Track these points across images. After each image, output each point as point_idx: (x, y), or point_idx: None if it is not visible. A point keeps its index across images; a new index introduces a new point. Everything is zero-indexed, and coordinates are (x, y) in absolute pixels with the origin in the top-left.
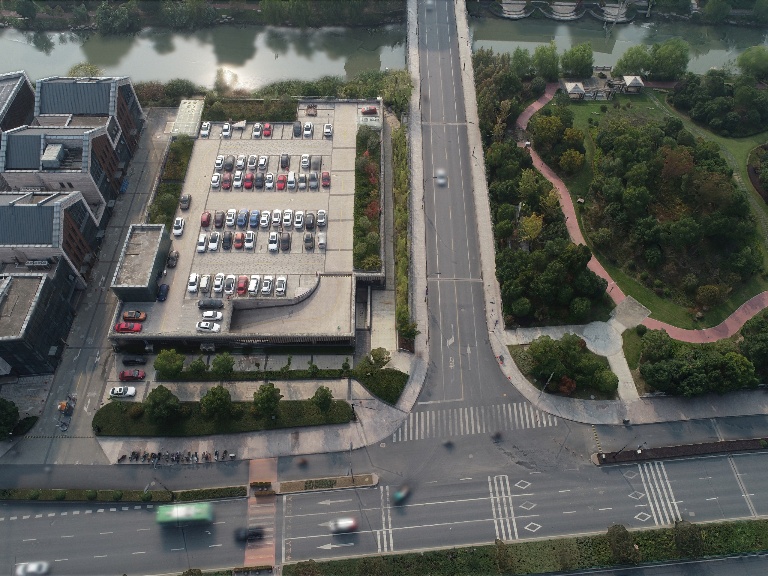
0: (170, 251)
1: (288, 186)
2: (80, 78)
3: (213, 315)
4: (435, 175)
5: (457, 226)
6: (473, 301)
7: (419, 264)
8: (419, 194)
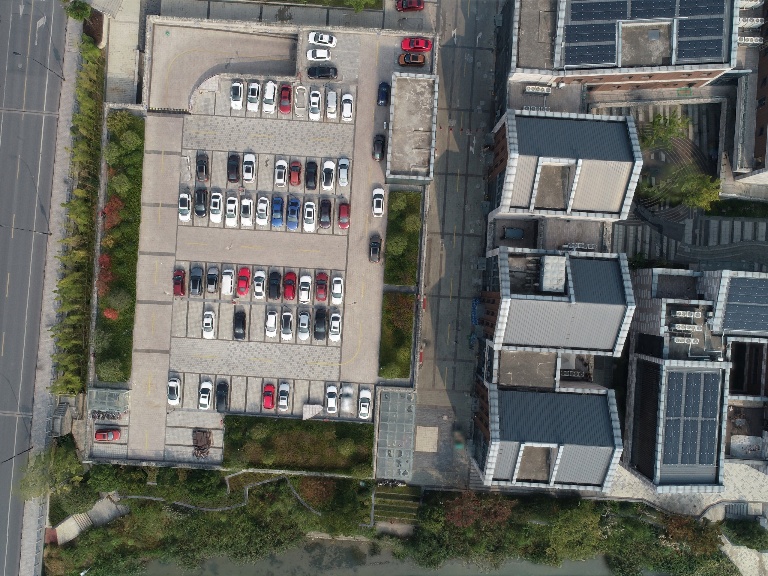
0: (385, 163)
1: (233, 271)
2: (565, 486)
3: (316, 52)
4: (25, 299)
5: (7, 200)
6: (5, 77)
7: (66, 137)
8: (52, 261)
